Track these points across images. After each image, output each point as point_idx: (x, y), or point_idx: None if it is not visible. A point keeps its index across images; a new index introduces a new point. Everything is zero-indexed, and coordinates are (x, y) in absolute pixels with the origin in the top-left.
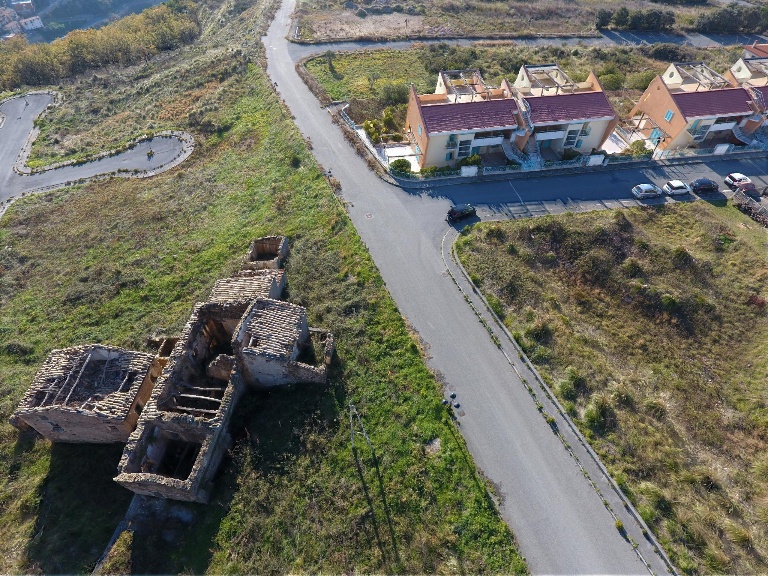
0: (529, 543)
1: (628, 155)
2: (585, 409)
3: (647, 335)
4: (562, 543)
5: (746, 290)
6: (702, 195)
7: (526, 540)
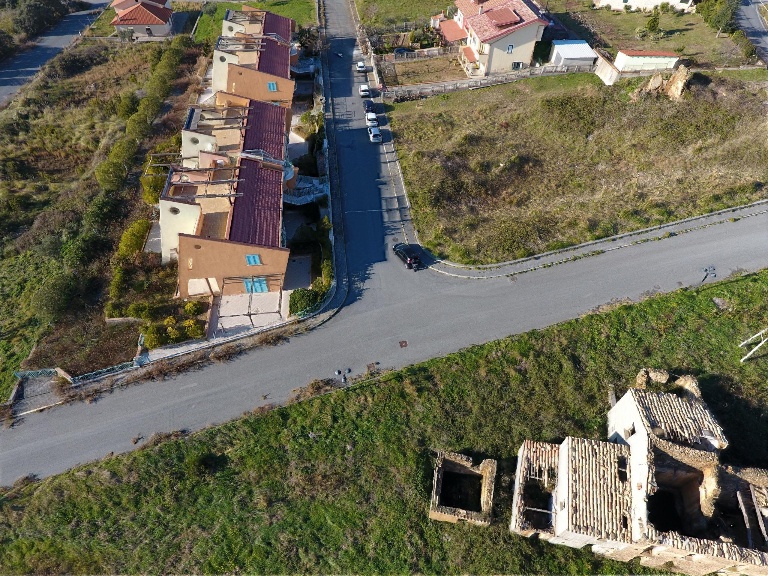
0: (766, 261)
1: (323, 127)
2: (655, 215)
3: (545, 181)
4: (757, 247)
5: (496, 126)
6: (378, 112)
7: (765, 262)
